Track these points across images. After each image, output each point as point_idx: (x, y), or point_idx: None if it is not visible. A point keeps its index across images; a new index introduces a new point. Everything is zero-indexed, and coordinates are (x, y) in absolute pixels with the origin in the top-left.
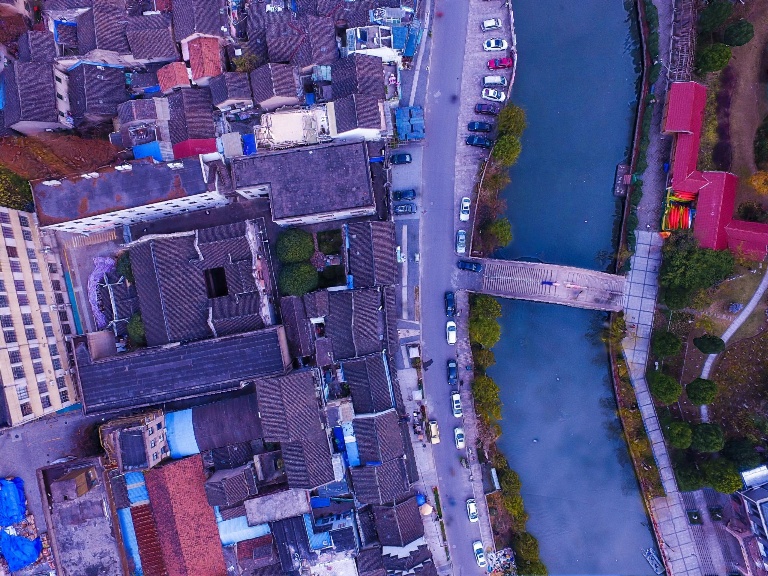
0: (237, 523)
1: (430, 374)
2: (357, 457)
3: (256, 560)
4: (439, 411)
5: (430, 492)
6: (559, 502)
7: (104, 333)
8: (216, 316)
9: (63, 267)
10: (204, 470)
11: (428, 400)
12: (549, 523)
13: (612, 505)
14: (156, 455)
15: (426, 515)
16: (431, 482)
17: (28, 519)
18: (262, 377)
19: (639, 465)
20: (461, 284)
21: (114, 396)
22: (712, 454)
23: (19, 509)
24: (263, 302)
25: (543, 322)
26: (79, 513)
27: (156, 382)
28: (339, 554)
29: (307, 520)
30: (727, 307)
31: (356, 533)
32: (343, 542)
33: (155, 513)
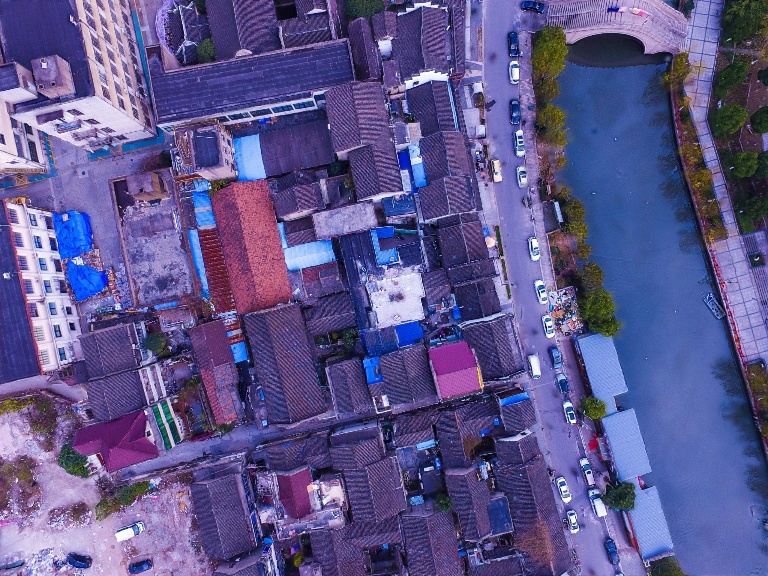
0: (302, 249)
1: (492, 115)
2: (423, 178)
3: (322, 279)
4: (501, 151)
5: (492, 231)
6: (616, 263)
7: (173, 58)
8: (286, 32)
9: (130, 7)
10: (270, 198)
11: (490, 140)
12: (606, 284)
13: (670, 262)
14: (227, 163)
15: None
16: (493, 221)
17: (95, 250)
18: (332, 87)
19: (700, 208)
20: (524, 26)
21: (186, 107)
22: None
23: (86, 239)
24: None
25: (600, 87)
26: (149, 225)
27: (227, 93)
28: (406, 269)
29: (374, 237)
30: None
31: None
32: (410, 257)
33: (222, 236)
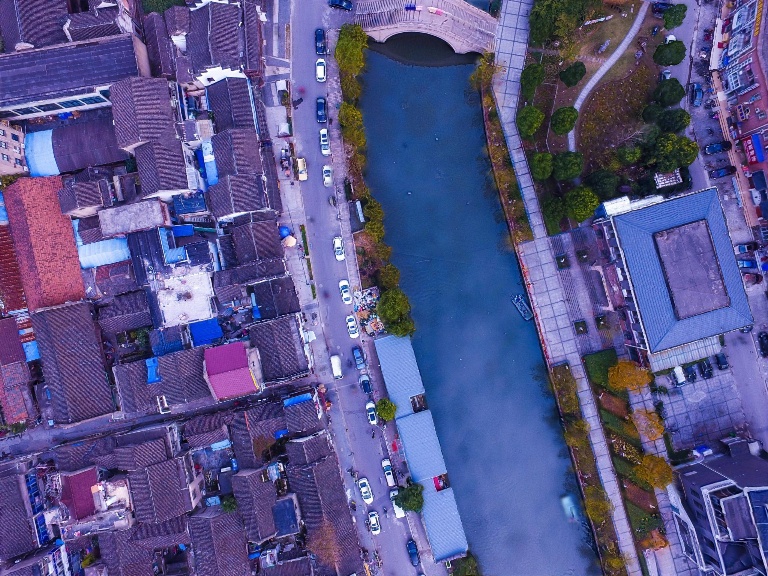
0: (97, 246)
1: (300, 113)
2: (216, 176)
3: (112, 277)
4: (308, 150)
5: (297, 230)
6: (436, 263)
7: None
8: (73, 26)
9: None
10: None
11: (297, 139)
12: (426, 284)
13: (488, 263)
14: (7, 158)
15: (293, 253)
16: (299, 220)
17: None
18: None
19: None
20: (332, 23)
21: None
22: (574, 184)
23: None
24: (122, 16)
25: (425, 86)
26: None
27: (10, 87)
28: (194, 268)
29: (163, 235)
30: (597, 50)
31: (216, 257)
32: (198, 256)
33: (13, 233)
